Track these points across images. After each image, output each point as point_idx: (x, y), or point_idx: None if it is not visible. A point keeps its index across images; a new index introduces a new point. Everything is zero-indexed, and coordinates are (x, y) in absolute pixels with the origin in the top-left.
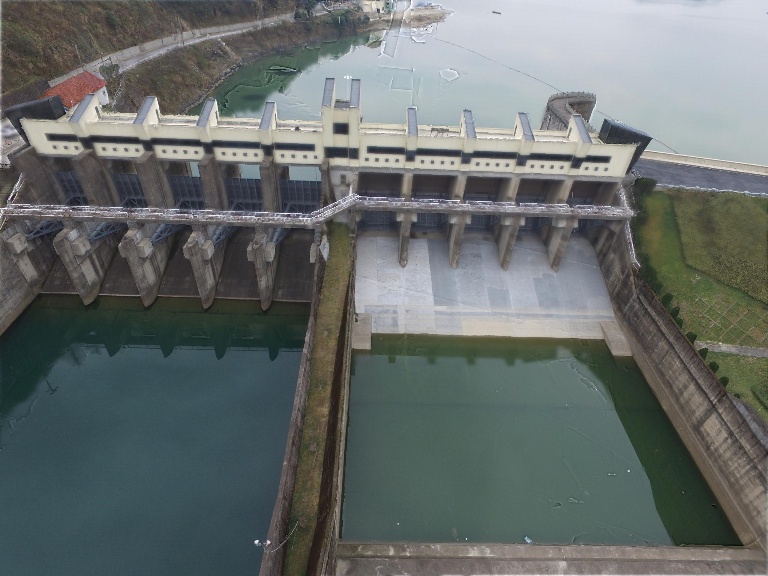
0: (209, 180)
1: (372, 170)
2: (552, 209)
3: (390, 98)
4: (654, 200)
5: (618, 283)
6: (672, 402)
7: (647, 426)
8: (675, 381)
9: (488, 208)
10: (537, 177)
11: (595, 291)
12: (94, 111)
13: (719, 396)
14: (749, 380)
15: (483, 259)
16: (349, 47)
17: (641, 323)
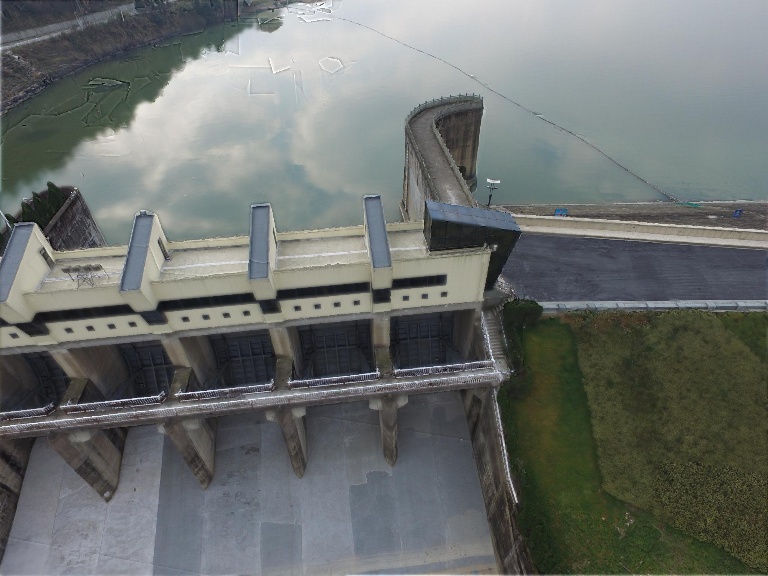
0: None
1: None
2: (343, 391)
3: (252, 106)
4: (542, 339)
5: (492, 499)
6: None
7: None
8: None
9: (215, 407)
10: (317, 321)
11: (460, 499)
12: None
13: None
14: None
15: (262, 456)
16: None
17: None
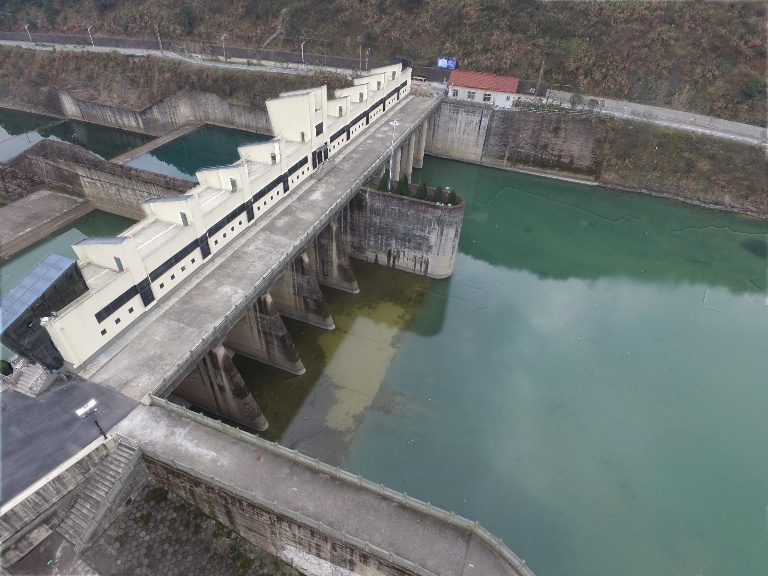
0: None
1: None
2: None
3: None
4: None
5: None
6: None
7: None
8: None
9: None
10: None
11: None
12: (391, 73)
13: None
14: None
15: None
16: None
17: None
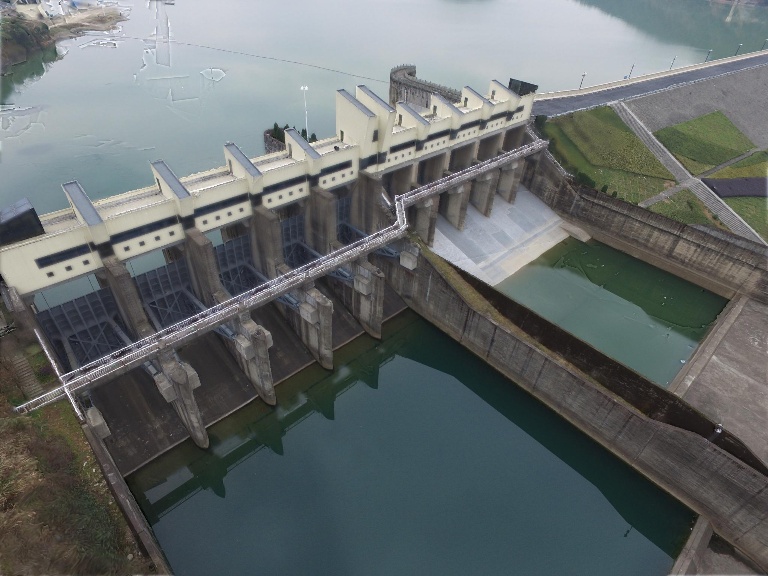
0: (280, 233)
1: (391, 169)
2: (512, 156)
3: (175, 112)
4: (549, 130)
5: (555, 195)
6: (642, 250)
7: (623, 275)
8: (639, 236)
9: (481, 170)
10: (488, 135)
11: (540, 207)
12: None
13: (681, 229)
14: None
15: (470, 216)
16: (41, 65)
17: (591, 213)
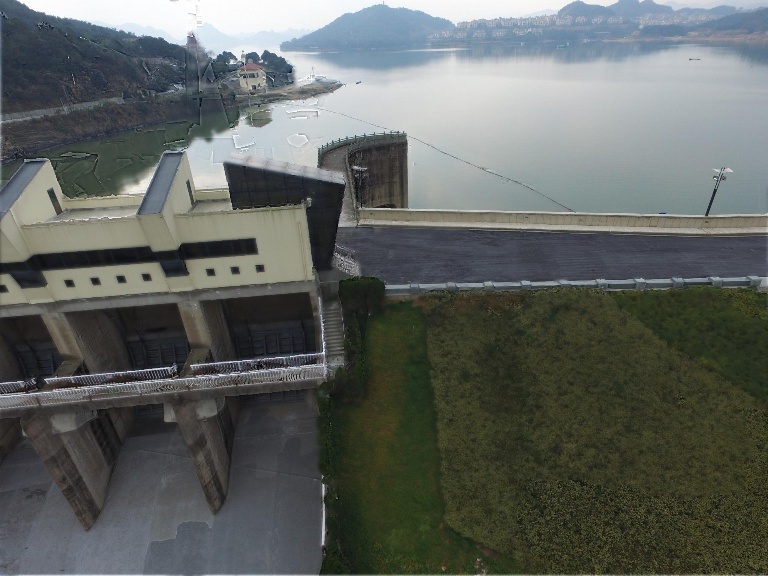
0: None
1: None
2: (112, 388)
3: None
4: (387, 327)
5: None
6: None
7: None
8: None
9: None
10: (103, 305)
11: (298, 560)
12: None
13: None
14: None
15: (47, 500)
16: None
17: None
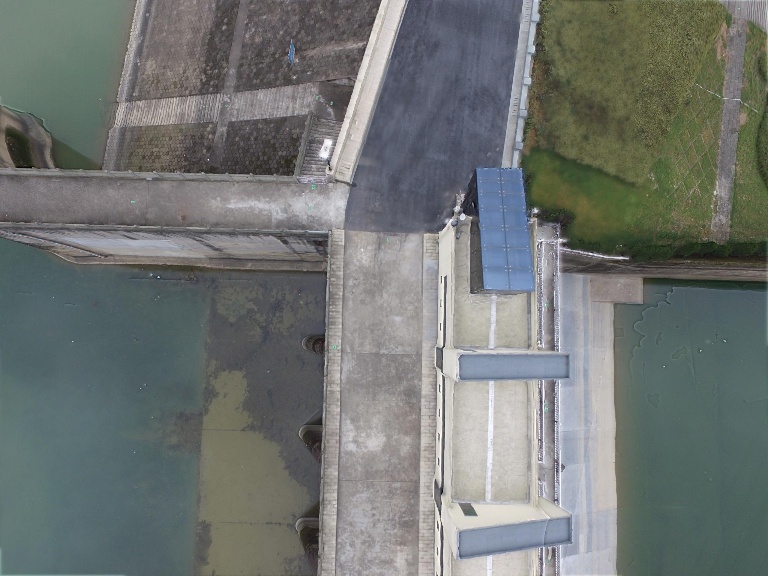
0: None
1: None
2: None
3: None
4: (536, 183)
5: None
6: None
7: None
8: None
9: None
10: None
11: None
12: None
13: None
14: (760, 189)
15: None
16: None
17: None
